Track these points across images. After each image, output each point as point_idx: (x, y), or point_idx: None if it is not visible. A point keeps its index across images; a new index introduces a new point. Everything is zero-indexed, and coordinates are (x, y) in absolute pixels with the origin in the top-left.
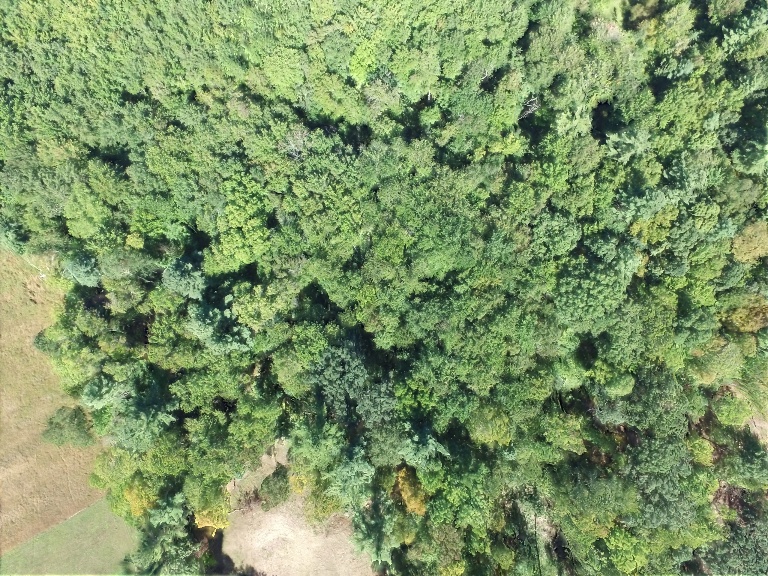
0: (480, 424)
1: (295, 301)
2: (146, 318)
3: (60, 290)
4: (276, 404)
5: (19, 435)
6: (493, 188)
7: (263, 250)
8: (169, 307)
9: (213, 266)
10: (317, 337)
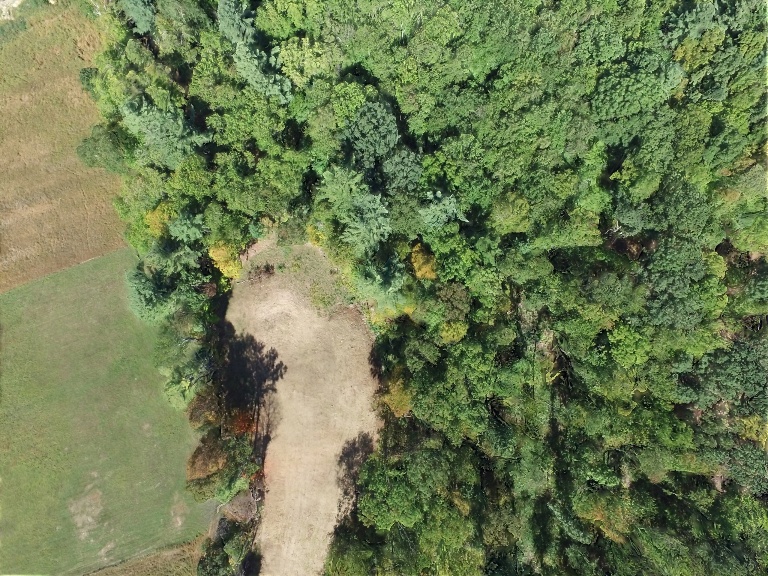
0: (501, 203)
1: (338, 68)
2: (190, 74)
3: (111, 36)
4: (306, 153)
5: (47, 178)
6: None
7: (316, 10)
8: (217, 47)
9: (265, 20)
10: (356, 93)
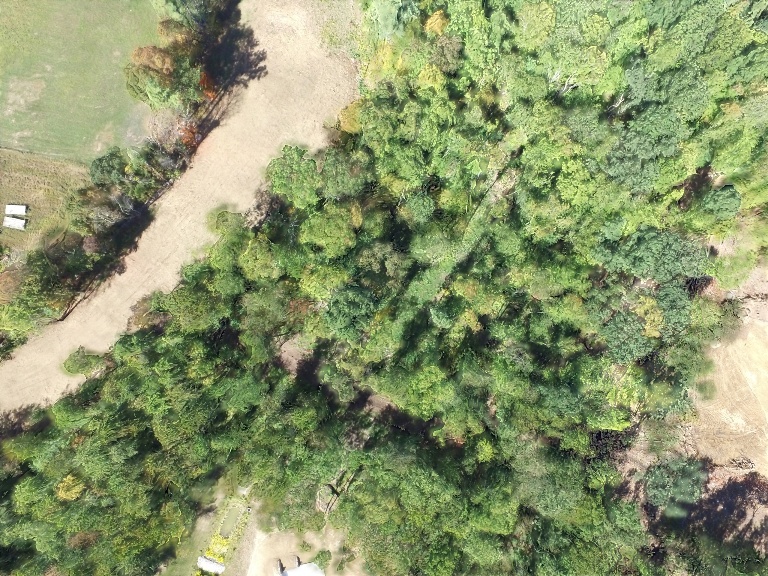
0: (532, 6)
1: None
2: None
3: None
4: None
5: None
6: None
7: None
8: None
9: None
10: None
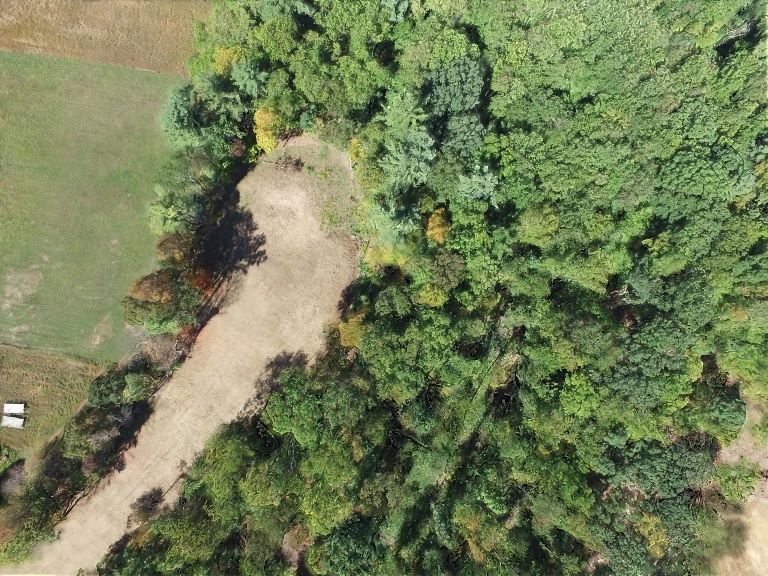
0: (535, 210)
1: (456, 17)
2: None
3: None
4: (388, 72)
5: None
6: (671, 56)
7: None
8: None
9: None
10: (461, 45)
